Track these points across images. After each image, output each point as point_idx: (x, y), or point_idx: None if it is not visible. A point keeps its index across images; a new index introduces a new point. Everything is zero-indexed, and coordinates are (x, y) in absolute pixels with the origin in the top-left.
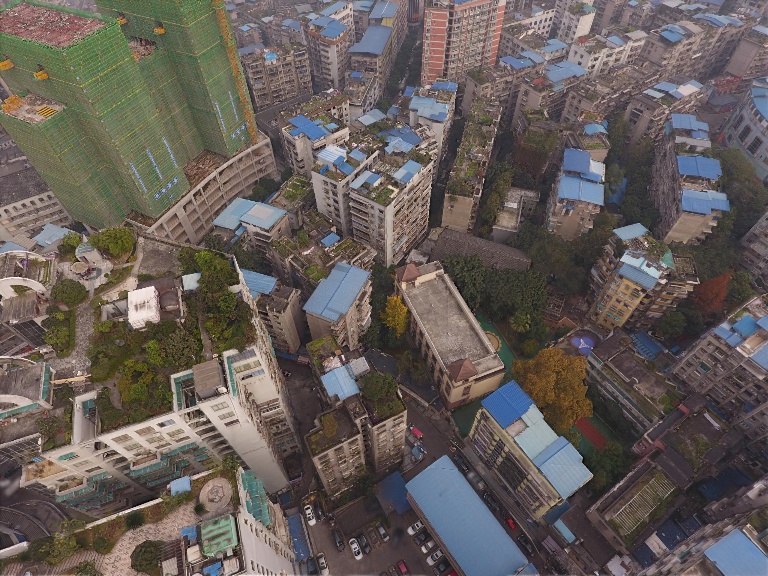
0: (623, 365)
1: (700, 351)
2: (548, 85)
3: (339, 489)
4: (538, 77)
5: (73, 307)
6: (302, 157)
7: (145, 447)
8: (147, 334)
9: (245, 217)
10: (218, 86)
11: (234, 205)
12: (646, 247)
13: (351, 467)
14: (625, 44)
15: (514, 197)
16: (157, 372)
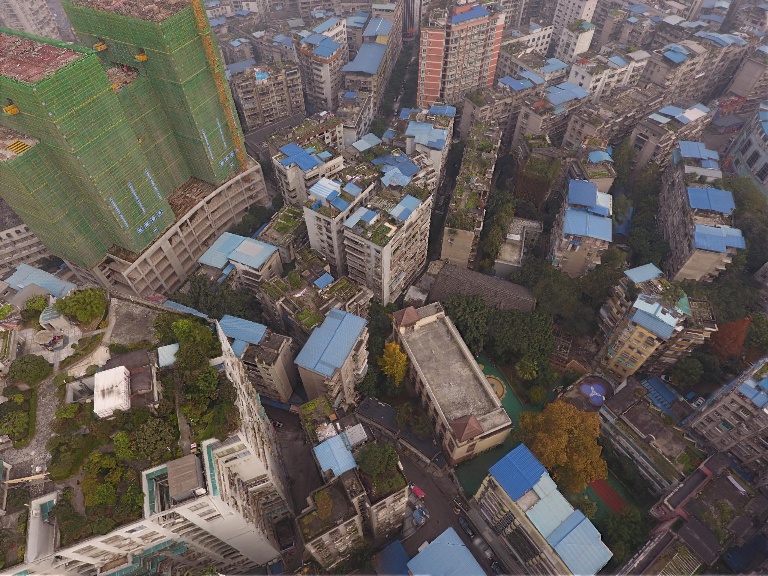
0: (638, 418)
1: (722, 408)
2: (549, 108)
3: (335, 560)
4: (539, 100)
5: (35, 384)
6: (294, 187)
7: (113, 552)
8: (115, 423)
9: (233, 255)
10: (205, 113)
11: (222, 241)
12: (660, 291)
13: (348, 541)
14: (627, 65)
15: (516, 228)
16: (127, 467)
